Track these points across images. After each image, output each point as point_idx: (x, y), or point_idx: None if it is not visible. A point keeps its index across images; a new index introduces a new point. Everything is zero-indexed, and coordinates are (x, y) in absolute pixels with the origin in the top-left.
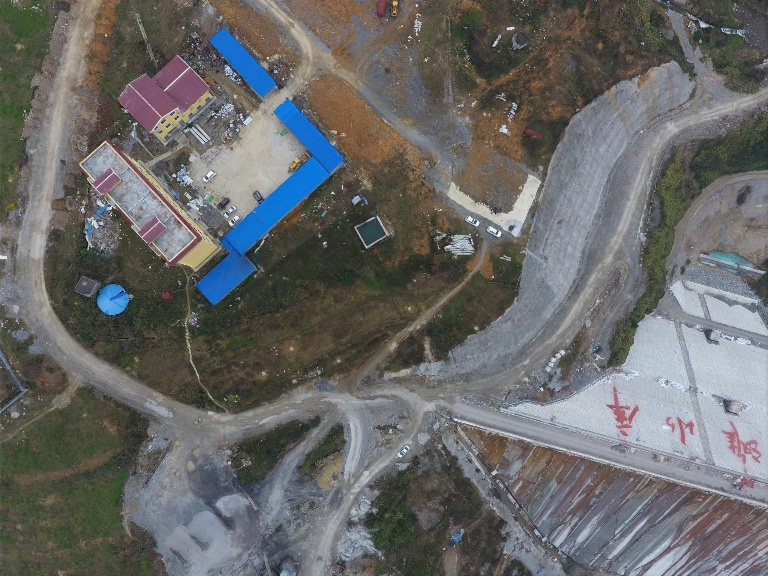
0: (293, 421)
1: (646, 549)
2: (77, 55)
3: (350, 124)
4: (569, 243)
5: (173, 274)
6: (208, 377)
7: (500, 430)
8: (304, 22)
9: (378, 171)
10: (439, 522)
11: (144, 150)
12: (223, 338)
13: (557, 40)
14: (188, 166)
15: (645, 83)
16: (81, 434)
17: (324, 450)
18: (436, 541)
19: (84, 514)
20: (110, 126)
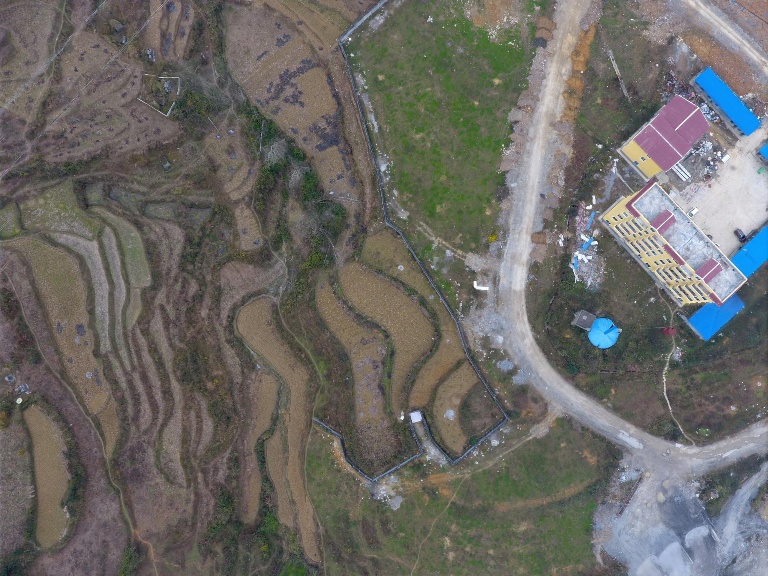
0: (753, 455)
1: None
2: (555, 91)
3: None
4: None
5: (658, 309)
6: (679, 410)
7: None
8: None
9: None
10: None
11: (625, 186)
12: (699, 372)
13: None
14: None
15: None
16: (559, 463)
17: None
18: None
19: (556, 541)
20: (585, 161)
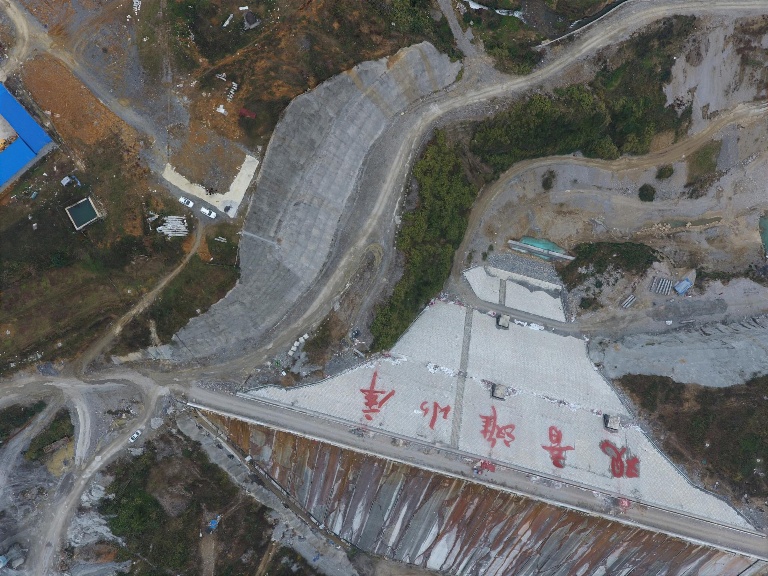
0: (14, 405)
1: (419, 536)
2: None
3: (65, 105)
4: (314, 226)
5: None
6: None
7: (235, 414)
8: (21, 2)
9: (92, 152)
10: (187, 508)
11: None
12: None
13: (291, 20)
14: None
15: (395, 64)
16: None
17: (51, 435)
18: (188, 528)
19: None
20: None
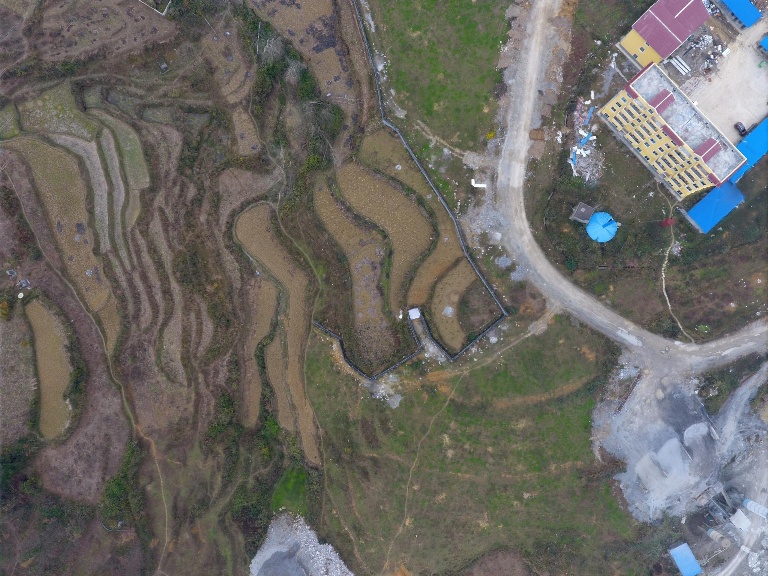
0: (752, 353)
1: None
2: None
3: None
4: None
5: (657, 203)
6: (678, 307)
7: None
8: None
9: None
10: None
11: (624, 81)
12: (698, 268)
13: None
14: None
15: None
16: (557, 360)
17: None
18: None
19: (554, 438)
20: (584, 57)
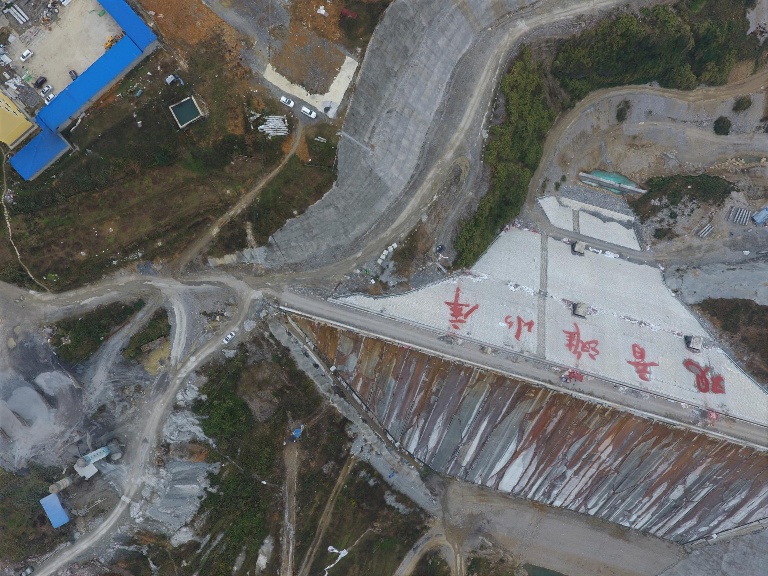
0: (115, 303)
1: (495, 454)
2: None
3: (168, 5)
4: (404, 136)
5: None
6: (28, 256)
7: (326, 319)
8: None
9: (194, 52)
10: (274, 414)
11: None
12: (41, 217)
13: None
14: (7, 46)
15: None
16: None
17: (149, 334)
18: (273, 434)
19: None
20: None
